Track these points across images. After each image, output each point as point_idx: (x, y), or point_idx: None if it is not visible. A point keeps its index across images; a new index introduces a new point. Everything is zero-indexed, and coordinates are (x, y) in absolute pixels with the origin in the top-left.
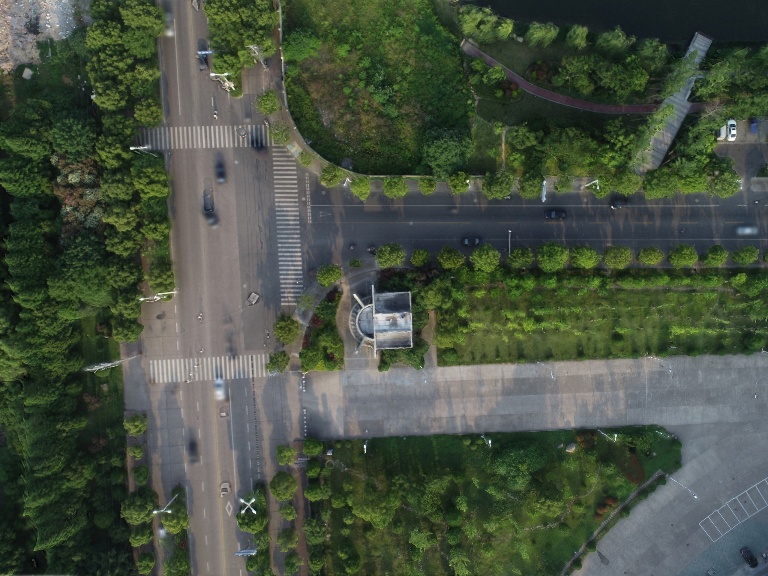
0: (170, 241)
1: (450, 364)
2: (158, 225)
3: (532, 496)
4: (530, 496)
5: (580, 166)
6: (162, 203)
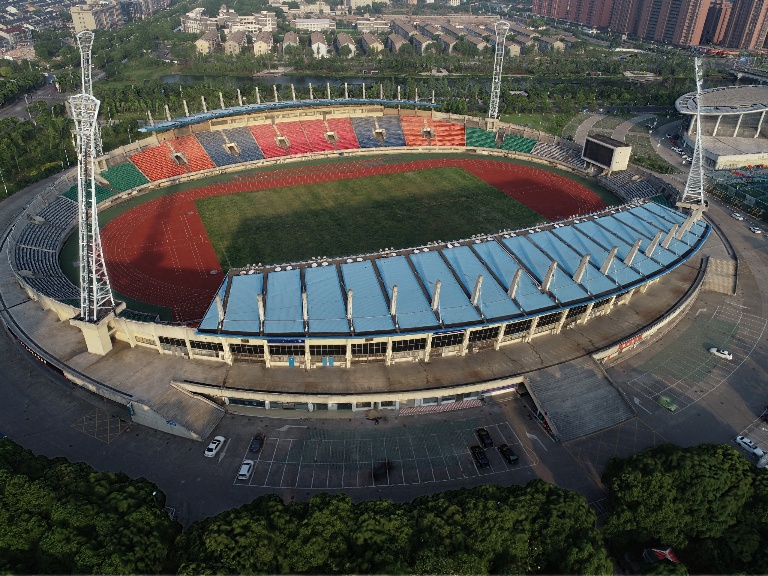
0: (9, 106)
1: (108, 118)
2: (8, 91)
3: (126, 134)
4: (125, 134)
5: (180, 93)
6: (13, 94)
